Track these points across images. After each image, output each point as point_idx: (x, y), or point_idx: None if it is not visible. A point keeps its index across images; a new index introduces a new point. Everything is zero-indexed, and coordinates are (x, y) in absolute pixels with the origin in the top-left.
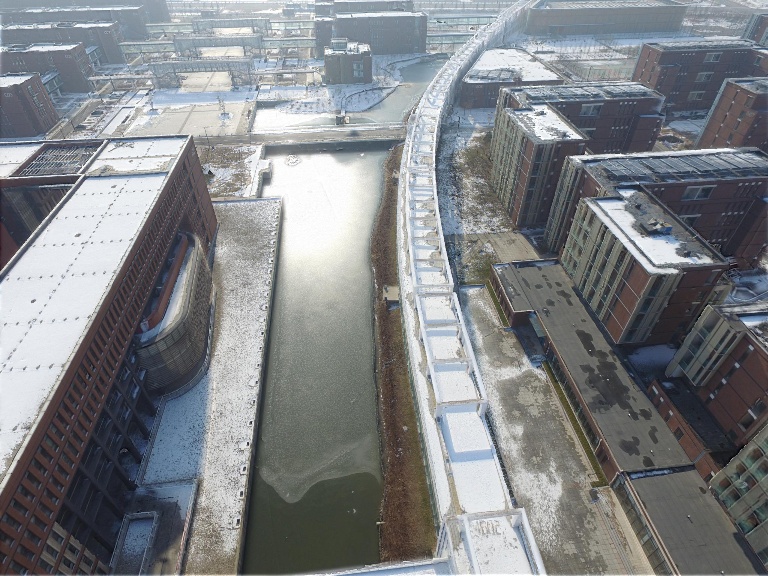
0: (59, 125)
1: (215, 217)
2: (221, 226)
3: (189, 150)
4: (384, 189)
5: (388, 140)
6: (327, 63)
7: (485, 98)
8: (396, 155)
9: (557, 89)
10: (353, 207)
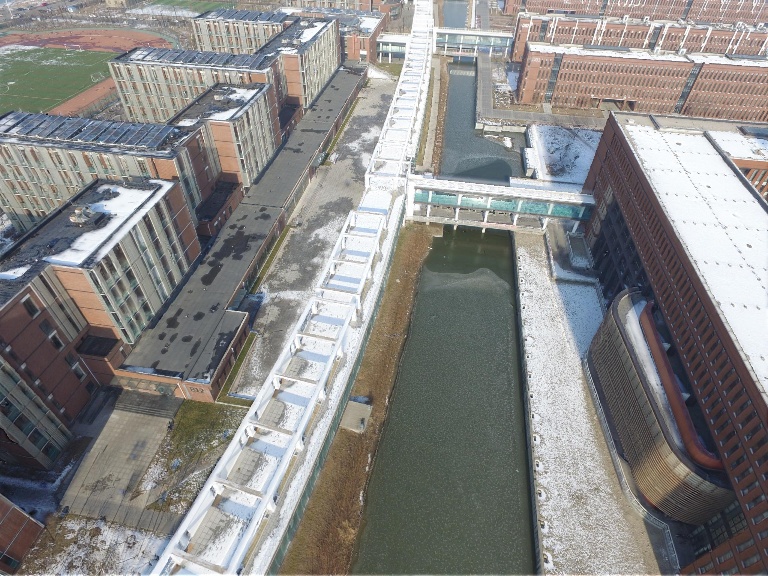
0: None
1: None
2: None
3: None
4: None
5: None
6: None
7: None
8: None
9: None
10: None
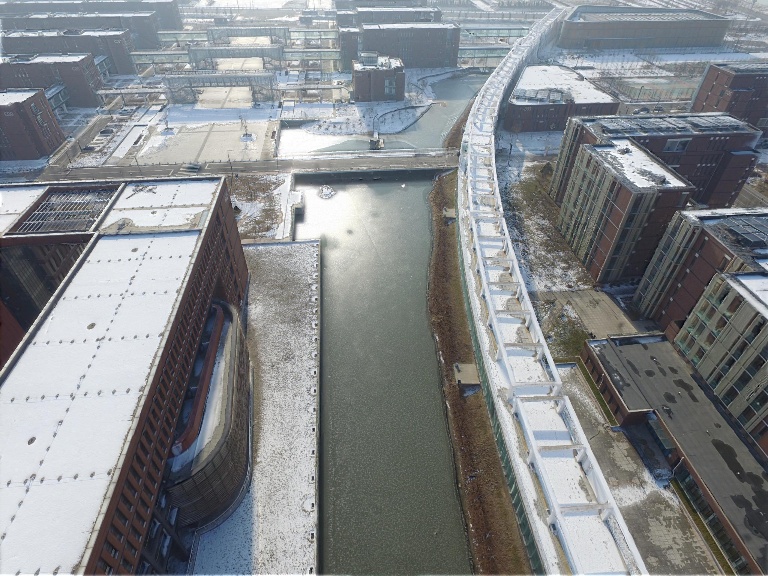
0: (65, 146)
1: (246, 267)
2: (252, 277)
3: (222, 196)
4: (434, 230)
5: (431, 169)
6: (357, 79)
7: (533, 121)
8: (442, 187)
9: (635, 120)
10: (401, 252)
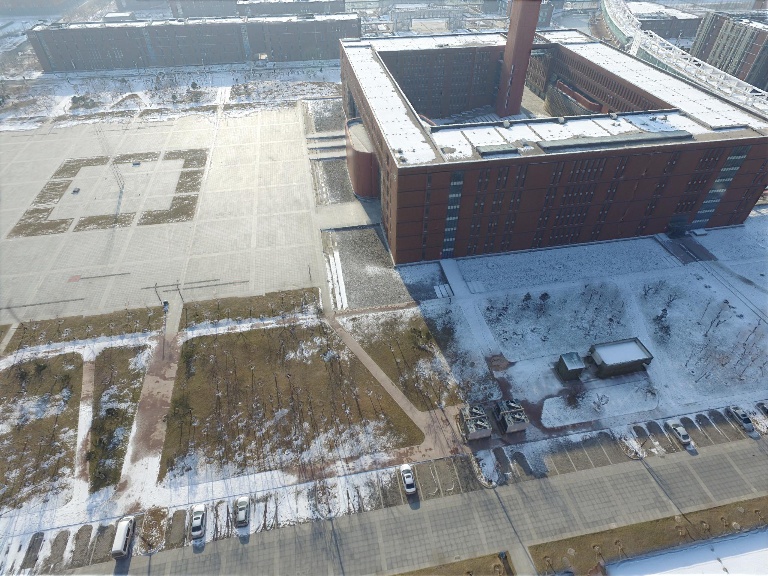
0: None
1: None
2: None
3: None
4: None
5: None
6: None
7: None
8: None
9: None
10: None
